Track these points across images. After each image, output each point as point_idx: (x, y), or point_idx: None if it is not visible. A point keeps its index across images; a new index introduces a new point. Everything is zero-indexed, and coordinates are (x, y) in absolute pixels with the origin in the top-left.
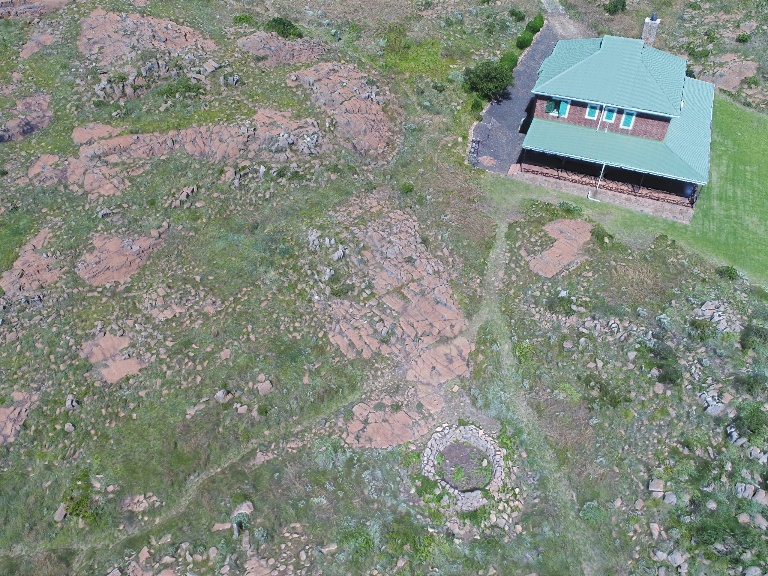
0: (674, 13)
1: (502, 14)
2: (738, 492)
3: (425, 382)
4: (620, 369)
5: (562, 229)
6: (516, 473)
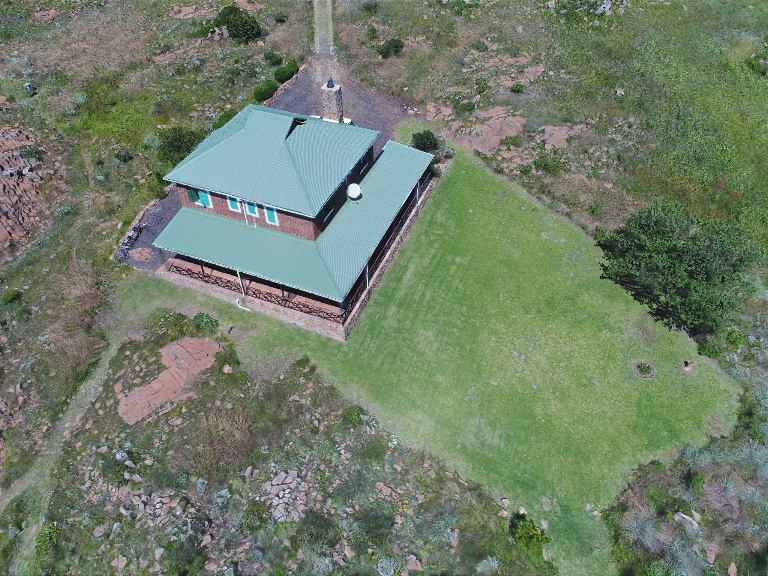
0: (453, 56)
1: (256, 57)
2: None
3: None
4: (143, 571)
5: (177, 354)
6: None
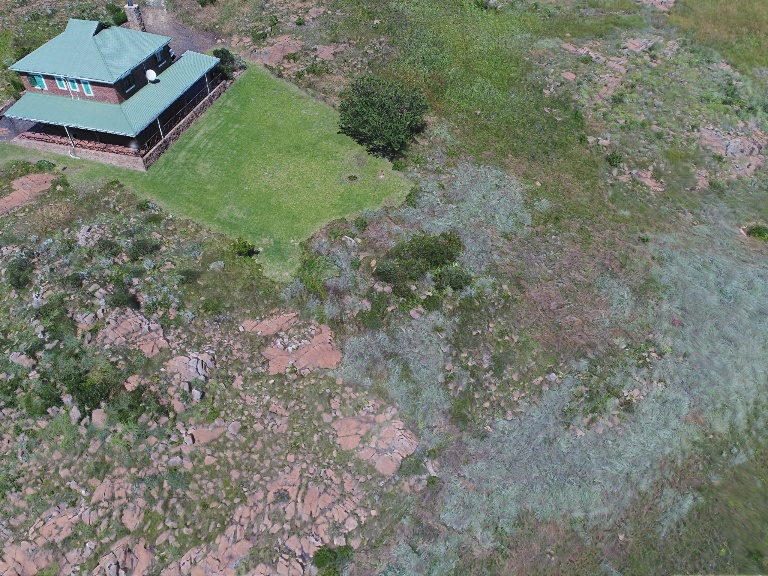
0: (256, 3)
1: (99, 8)
2: (9, 359)
3: None
4: None
5: (23, 181)
6: None
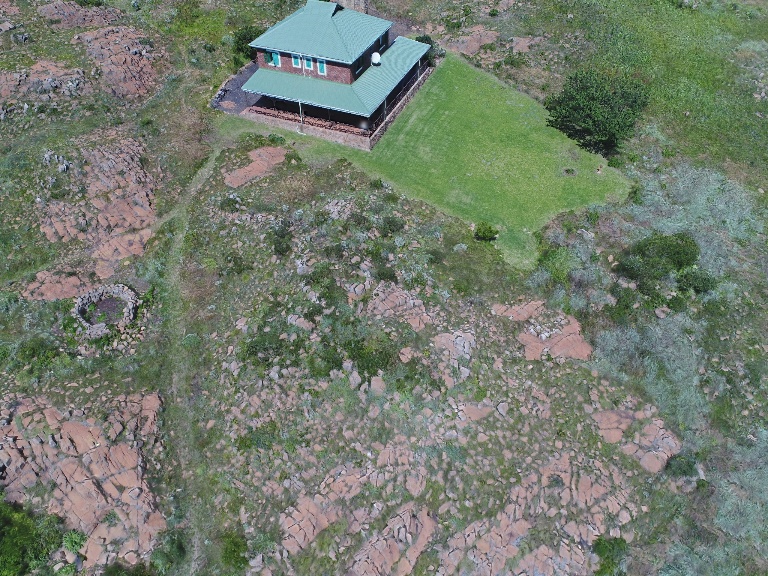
0: None
1: None
2: None
3: (105, 259)
4: (253, 248)
5: (260, 153)
6: (148, 318)
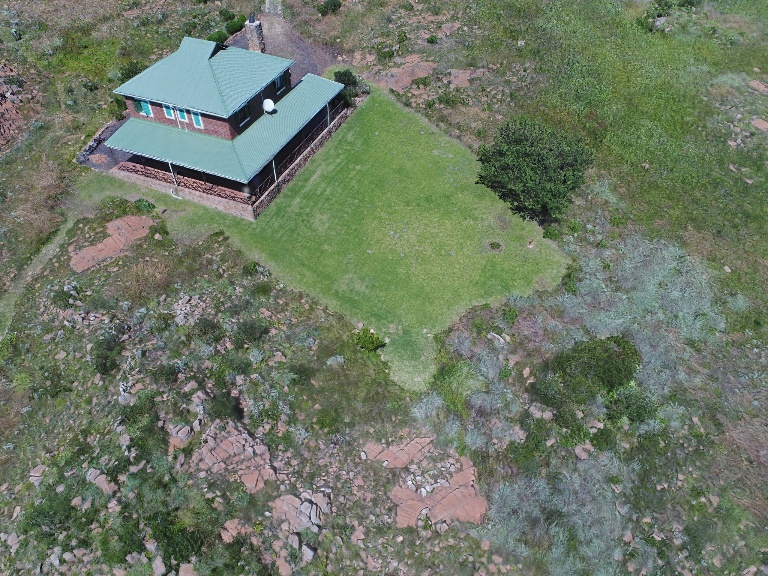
0: (382, 14)
1: (212, 14)
2: (87, 477)
3: None
4: (78, 360)
5: (119, 225)
6: None
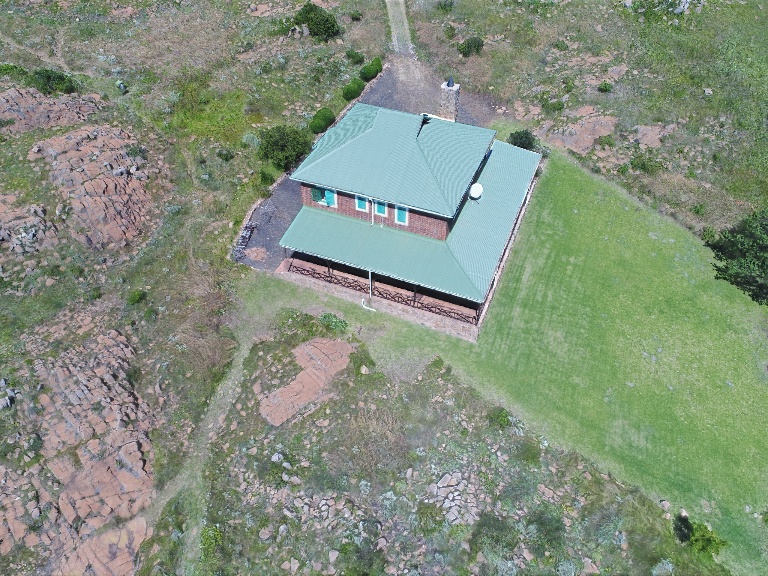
0: (535, 55)
1: (338, 56)
2: None
3: None
4: (317, 574)
5: (312, 355)
6: None
